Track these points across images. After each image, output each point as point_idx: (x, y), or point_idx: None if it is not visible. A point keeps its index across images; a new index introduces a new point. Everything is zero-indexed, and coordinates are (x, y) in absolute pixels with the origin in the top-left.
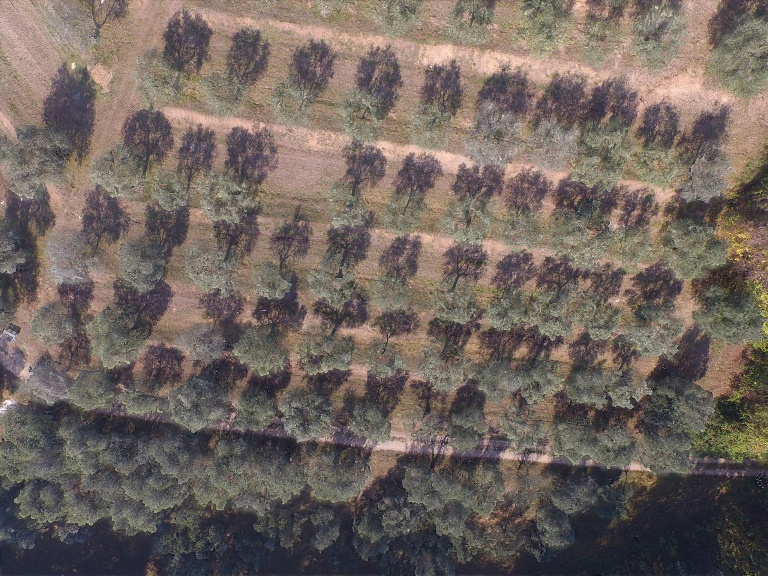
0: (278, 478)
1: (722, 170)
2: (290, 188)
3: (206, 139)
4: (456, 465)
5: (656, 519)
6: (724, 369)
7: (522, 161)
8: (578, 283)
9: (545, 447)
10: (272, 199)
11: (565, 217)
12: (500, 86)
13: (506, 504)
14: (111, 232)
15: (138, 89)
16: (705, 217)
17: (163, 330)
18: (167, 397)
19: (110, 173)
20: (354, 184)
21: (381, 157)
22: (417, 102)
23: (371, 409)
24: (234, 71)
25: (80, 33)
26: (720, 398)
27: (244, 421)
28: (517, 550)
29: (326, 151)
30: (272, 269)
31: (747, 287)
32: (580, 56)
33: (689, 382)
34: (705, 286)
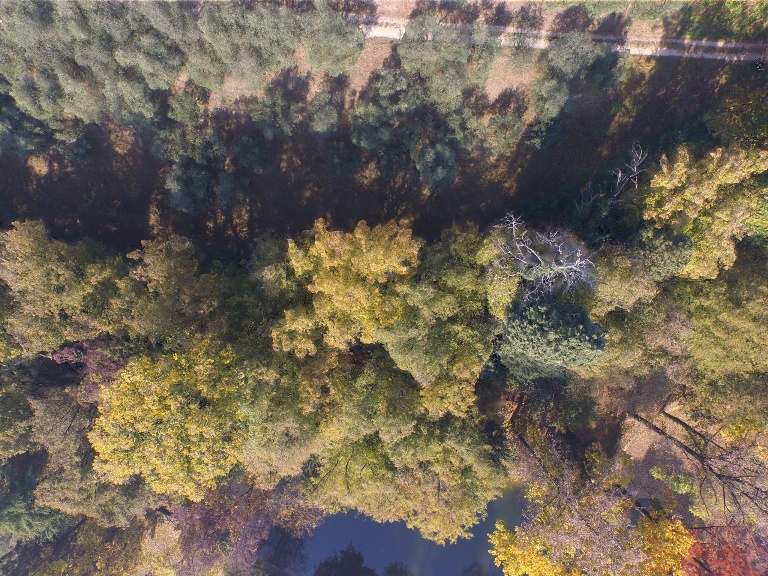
0: None
1: None
2: None
3: None
4: None
5: (656, 121)
6: None
7: None
8: None
9: (541, 32)
10: None
11: None
12: None
13: (504, 105)
14: None
15: None
16: None
17: None
18: None
19: None
20: None
21: None
22: None
23: None
24: None
25: None
26: None
27: None
28: (518, 165)
29: None
30: None
31: None
32: None
33: None
34: None
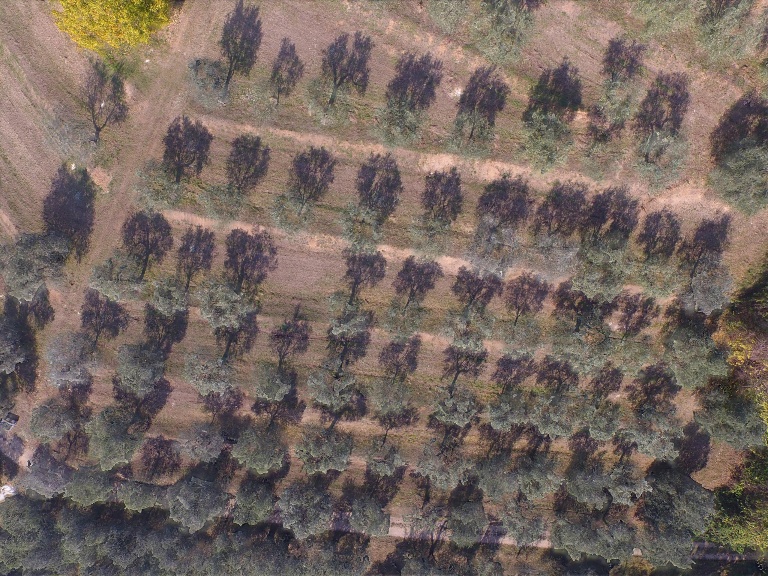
0: (276, 575)
1: (723, 286)
2: (290, 288)
3: (206, 240)
4: (455, 550)
5: None
6: (725, 460)
7: (522, 265)
8: (578, 379)
9: (545, 532)
10: (272, 298)
11: (565, 317)
12: (501, 192)
13: None
14: (110, 328)
15: (138, 200)
16: (706, 319)
17: (162, 423)
18: (166, 485)
19: (109, 282)
20: (354, 284)
21: (381, 258)
22: (417, 207)
23: (370, 505)
24: (234, 175)
25: (80, 136)
26: (721, 488)
27: (243, 516)
28: None
29: (326, 252)
30: (271, 366)
31: (748, 395)
32: (581, 166)
33: (690, 480)
34: (706, 383)
